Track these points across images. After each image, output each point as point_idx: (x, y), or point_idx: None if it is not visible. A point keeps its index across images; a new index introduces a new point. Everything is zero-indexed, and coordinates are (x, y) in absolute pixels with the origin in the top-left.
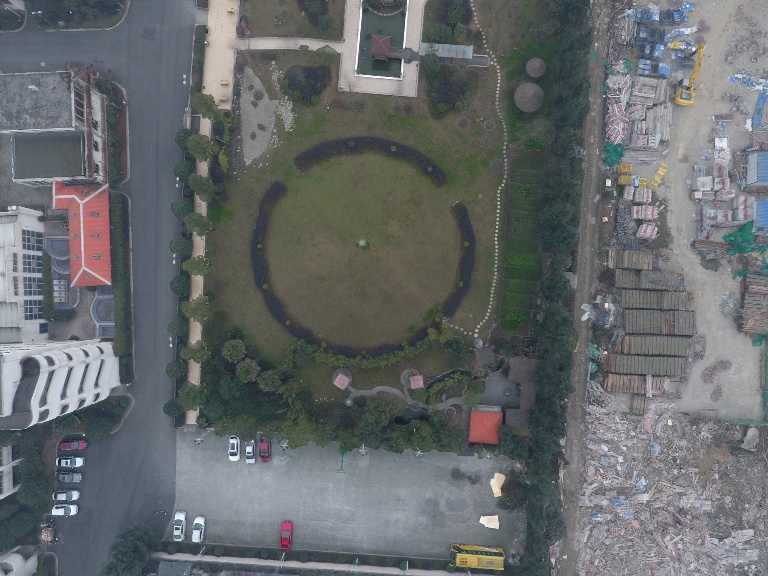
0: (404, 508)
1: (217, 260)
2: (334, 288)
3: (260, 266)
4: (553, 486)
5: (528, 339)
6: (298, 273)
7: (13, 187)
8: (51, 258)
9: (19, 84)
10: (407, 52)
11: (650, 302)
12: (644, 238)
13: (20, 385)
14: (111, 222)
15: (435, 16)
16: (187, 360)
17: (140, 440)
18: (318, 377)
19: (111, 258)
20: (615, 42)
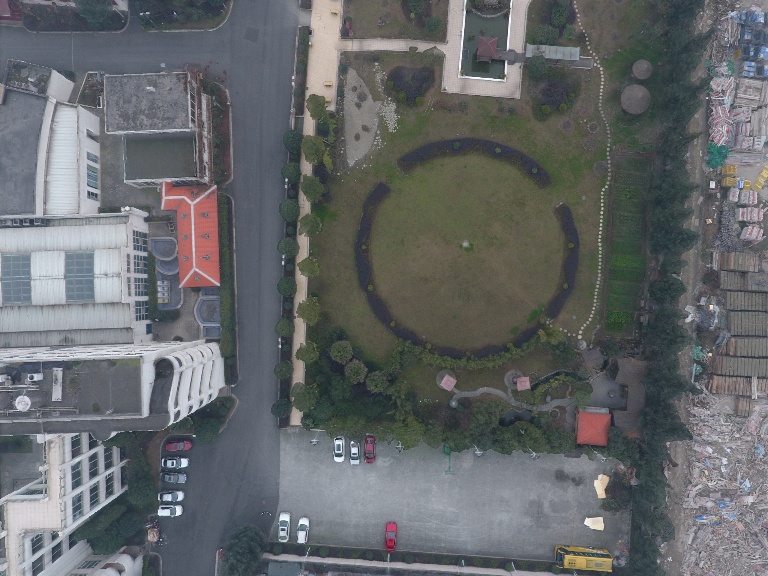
0: (508, 509)
1: (321, 261)
2: (438, 289)
3: (365, 267)
4: (672, 488)
5: (632, 341)
6: (402, 274)
7: (118, 188)
8: (155, 259)
9: (135, 85)
10: (511, 54)
11: (755, 304)
12: (749, 240)
13: (154, 386)
14: (218, 223)
15: (538, 18)
16: (291, 361)
17: (244, 441)
18: (422, 378)
19: (219, 259)
20: (718, 44)
